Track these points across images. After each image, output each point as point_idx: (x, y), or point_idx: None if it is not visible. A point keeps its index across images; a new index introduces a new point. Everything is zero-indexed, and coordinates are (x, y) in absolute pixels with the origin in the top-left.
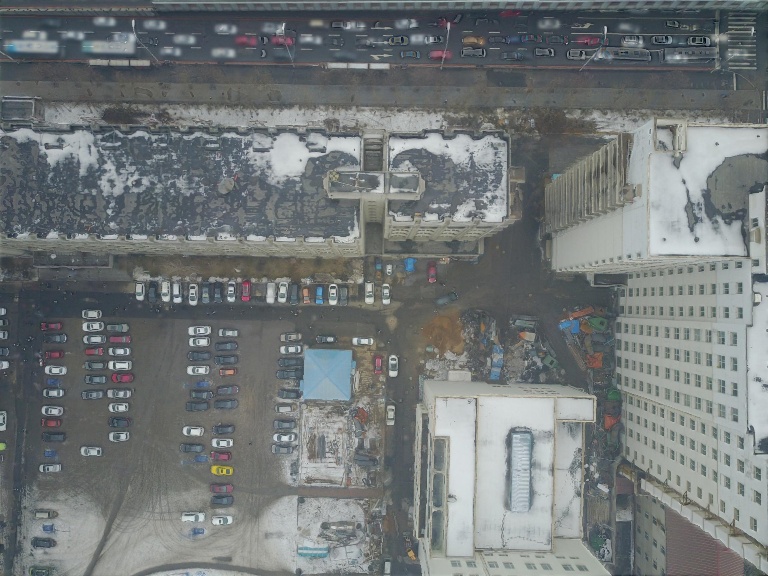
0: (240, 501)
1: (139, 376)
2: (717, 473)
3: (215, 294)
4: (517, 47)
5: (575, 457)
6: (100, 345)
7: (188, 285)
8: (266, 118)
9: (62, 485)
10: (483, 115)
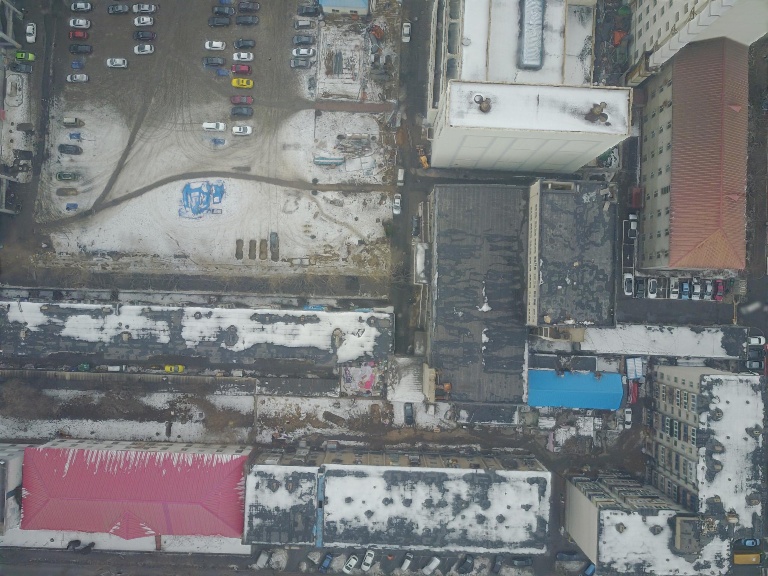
0: (259, 114)
1: None
2: None
3: None
4: None
5: (585, 45)
6: None
7: None
8: None
9: (88, 96)
10: None
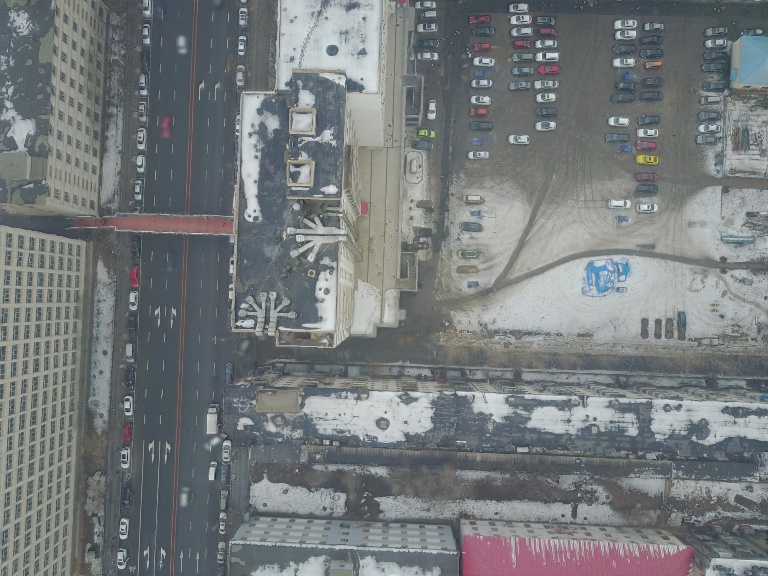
0: (664, 191)
1: (564, 69)
2: None
3: None
4: None
5: None
6: (527, 38)
7: None
8: None
9: (488, 173)
10: None
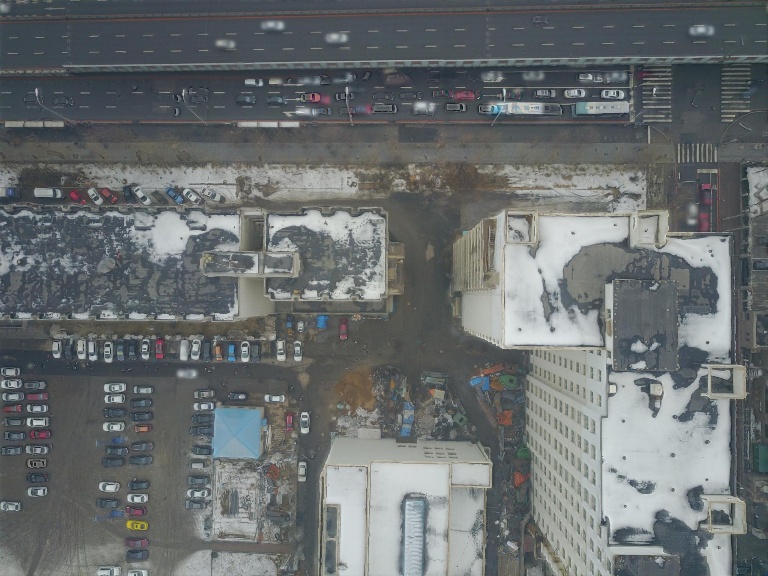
0: (155, 555)
1: (57, 432)
2: (586, 556)
3: (129, 352)
4: (429, 102)
5: (477, 519)
6: (19, 402)
7: (104, 343)
8: (179, 176)
9: None
10: (394, 171)
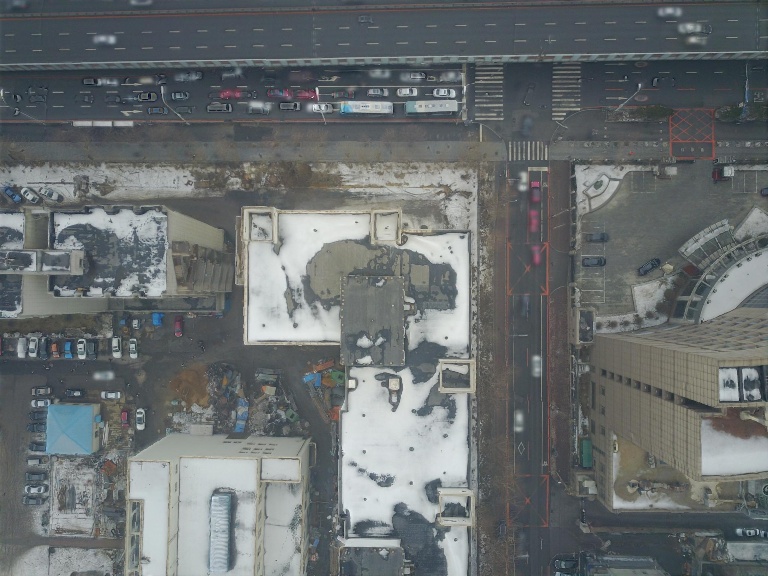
0: None
1: None
2: None
3: None
4: (265, 101)
5: (296, 513)
6: None
7: None
8: (18, 175)
9: None
10: (230, 170)
